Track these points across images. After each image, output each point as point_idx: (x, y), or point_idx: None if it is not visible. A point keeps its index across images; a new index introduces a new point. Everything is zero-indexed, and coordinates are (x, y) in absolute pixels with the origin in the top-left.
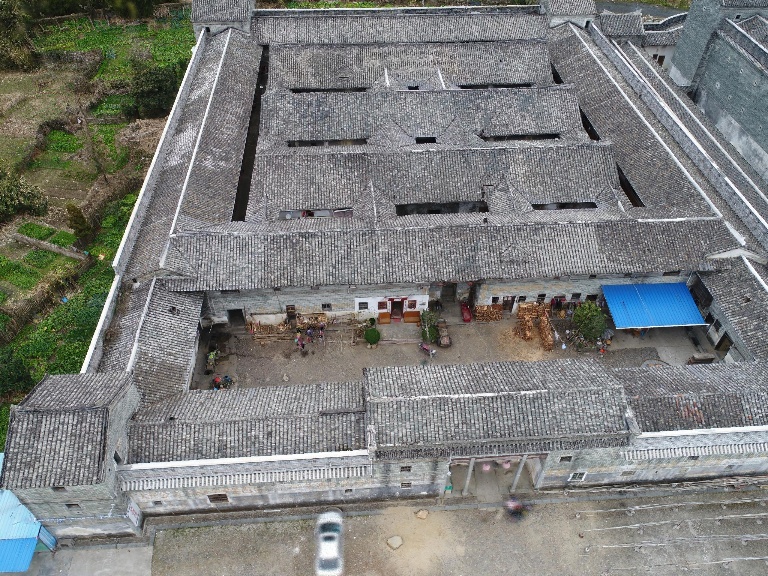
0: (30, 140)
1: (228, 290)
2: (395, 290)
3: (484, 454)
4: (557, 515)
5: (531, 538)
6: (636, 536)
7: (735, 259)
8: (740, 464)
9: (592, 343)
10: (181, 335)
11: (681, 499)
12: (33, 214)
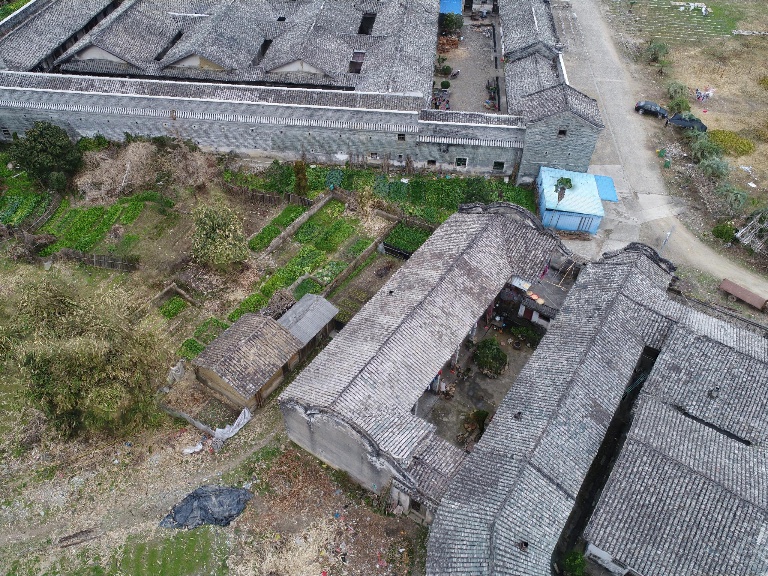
0: None
1: None
2: None
3: None
4: None
5: None
6: None
7: None
8: None
9: None
10: None
11: None
12: None
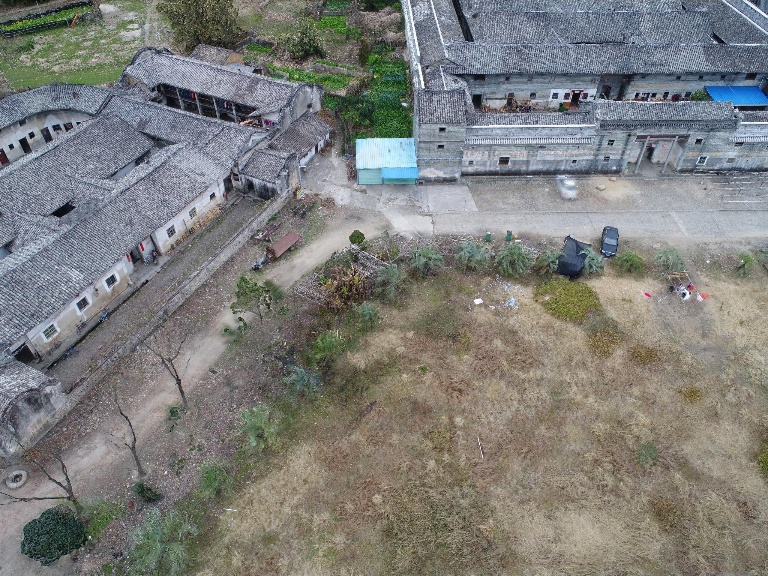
0: (292, 22)
1: (478, 78)
2: (577, 84)
3: (657, 129)
4: (690, 182)
5: (677, 190)
6: (736, 191)
7: None
8: None
9: None
10: None
11: (761, 179)
12: (319, 57)
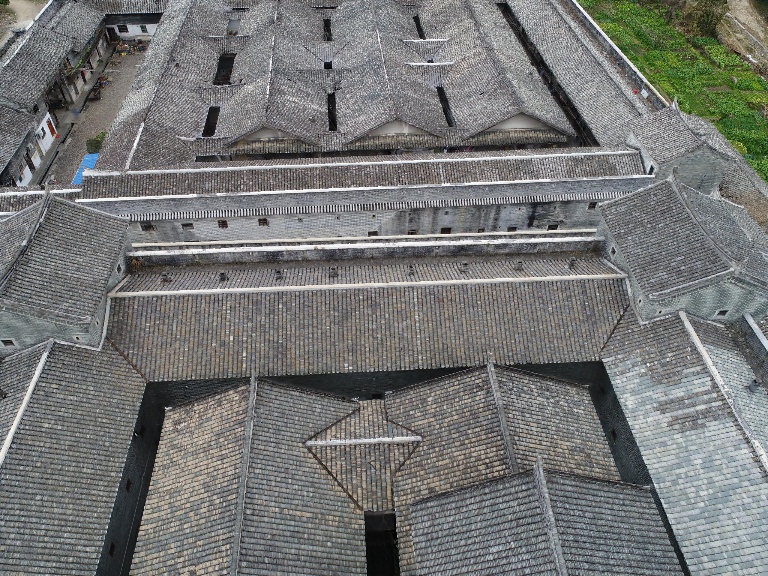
0: None
1: None
2: None
3: None
4: None
5: None
6: None
7: None
8: None
9: None
10: (141, 7)
11: None
12: None
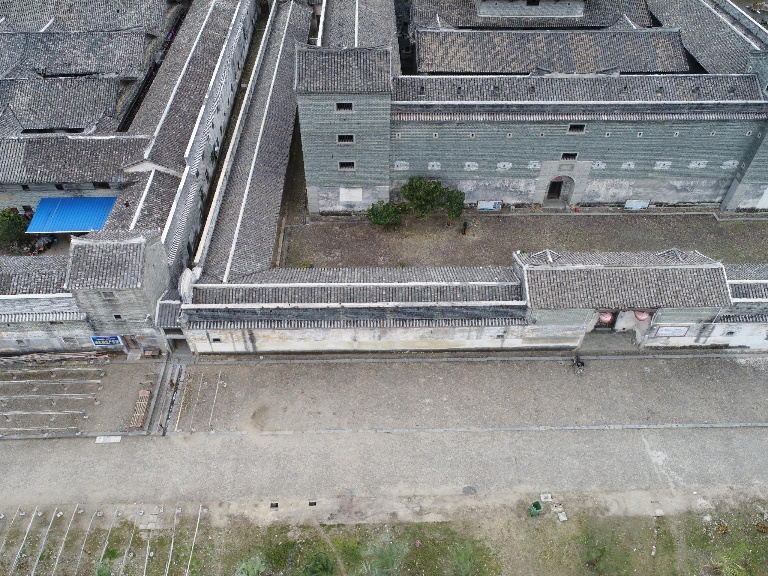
0: None
1: None
2: None
3: None
4: None
5: None
6: None
7: (148, 172)
8: (26, 339)
9: (21, 249)
10: None
11: None
12: None
